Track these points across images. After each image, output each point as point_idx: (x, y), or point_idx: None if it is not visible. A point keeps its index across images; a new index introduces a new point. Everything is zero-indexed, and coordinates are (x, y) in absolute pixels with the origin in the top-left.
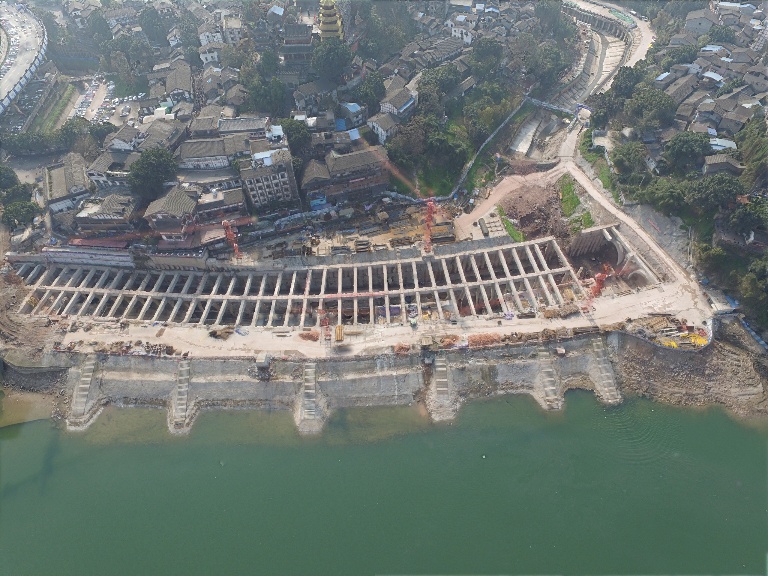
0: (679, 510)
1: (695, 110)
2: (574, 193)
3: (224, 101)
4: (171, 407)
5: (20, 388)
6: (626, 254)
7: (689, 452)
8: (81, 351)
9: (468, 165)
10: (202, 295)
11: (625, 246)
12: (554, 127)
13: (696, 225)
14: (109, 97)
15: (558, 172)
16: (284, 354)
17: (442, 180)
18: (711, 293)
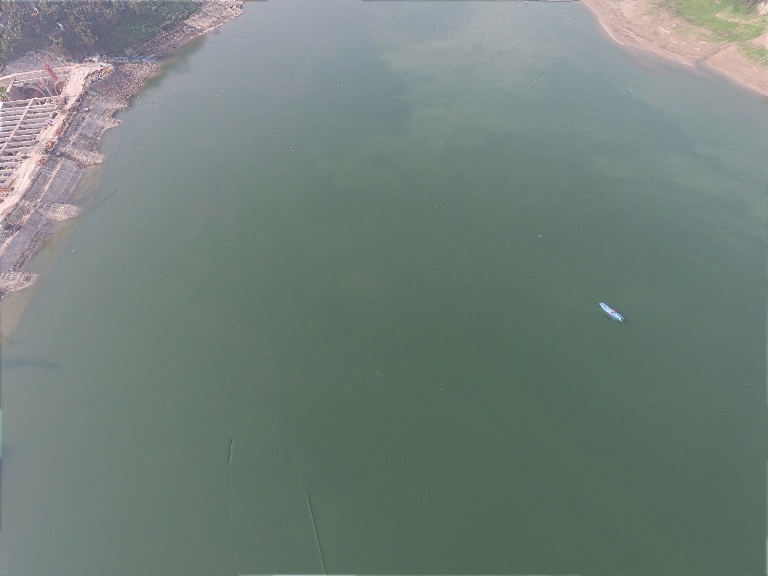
0: (184, 96)
1: None
2: None
3: None
4: (7, 286)
5: None
6: (39, 86)
7: (163, 90)
8: None
9: None
10: None
11: (33, 80)
12: None
13: (39, 46)
14: None
15: None
16: (3, 215)
17: None
18: (86, 59)
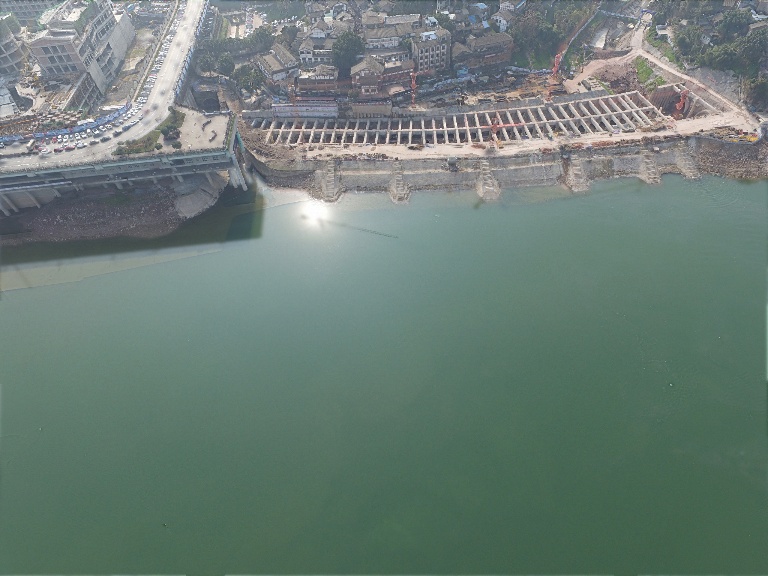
0: (748, 224)
1: (737, 3)
2: (647, 66)
3: (378, 9)
4: (392, 190)
5: (281, 186)
6: (691, 102)
7: (751, 199)
8: (323, 159)
9: (563, 52)
10: (393, 130)
11: (691, 94)
12: (620, 32)
13: (745, 72)
14: (266, 21)
15: (632, 56)
16: (465, 156)
17: (549, 58)
18: (758, 113)
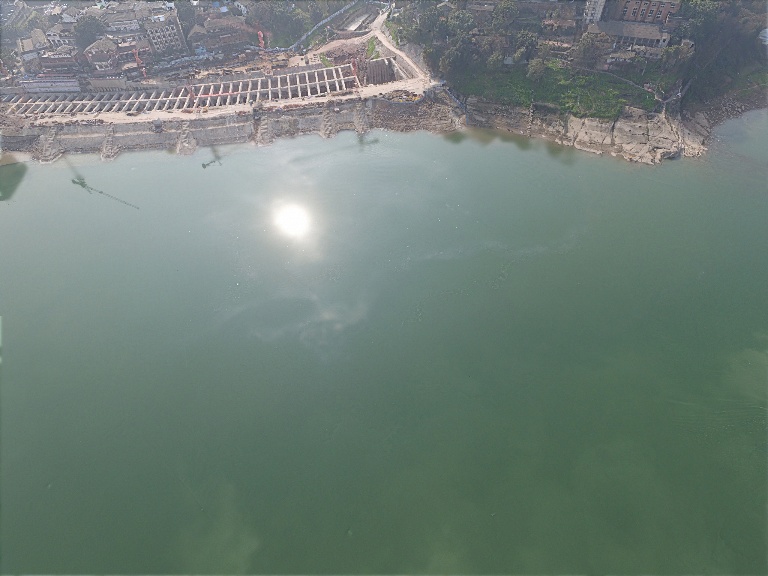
0: (382, 166)
1: None
2: (373, 44)
3: None
4: (103, 150)
5: (10, 150)
6: None
7: (398, 148)
8: (47, 125)
9: (308, 34)
10: (123, 100)
11: (395, 66)
12: None
13: None
14: None
15: (369, 36)
16: (171, 119)
17: (285, 38)
18: (432, 78)
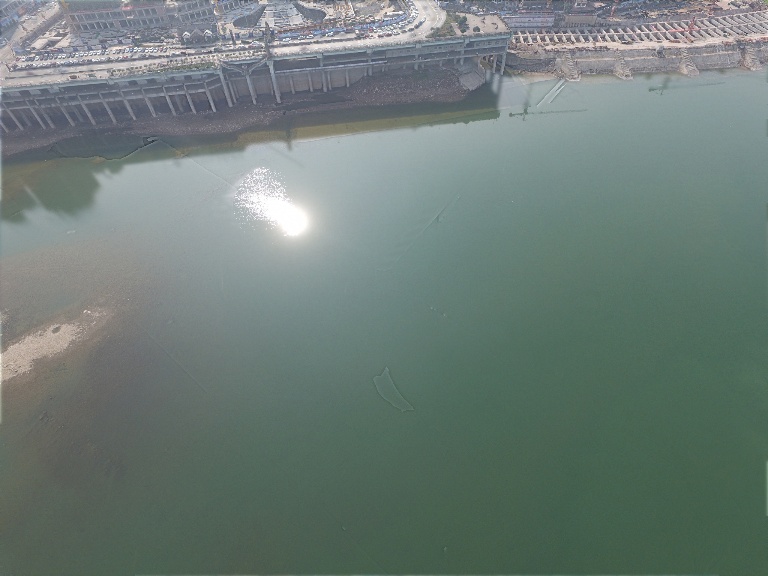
0: None
1: None
2: None
3: None
4: (618, 71)
5: (528, 71)
6: None
7: None
8: (561, 50)
9: None
10: None
11: None
12: None
13: None
14: None
15: None
16: None
17: None
18: None
